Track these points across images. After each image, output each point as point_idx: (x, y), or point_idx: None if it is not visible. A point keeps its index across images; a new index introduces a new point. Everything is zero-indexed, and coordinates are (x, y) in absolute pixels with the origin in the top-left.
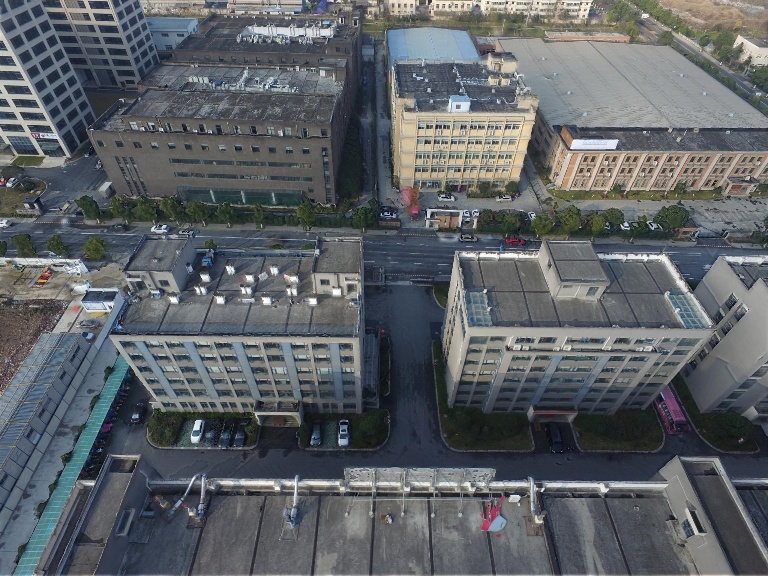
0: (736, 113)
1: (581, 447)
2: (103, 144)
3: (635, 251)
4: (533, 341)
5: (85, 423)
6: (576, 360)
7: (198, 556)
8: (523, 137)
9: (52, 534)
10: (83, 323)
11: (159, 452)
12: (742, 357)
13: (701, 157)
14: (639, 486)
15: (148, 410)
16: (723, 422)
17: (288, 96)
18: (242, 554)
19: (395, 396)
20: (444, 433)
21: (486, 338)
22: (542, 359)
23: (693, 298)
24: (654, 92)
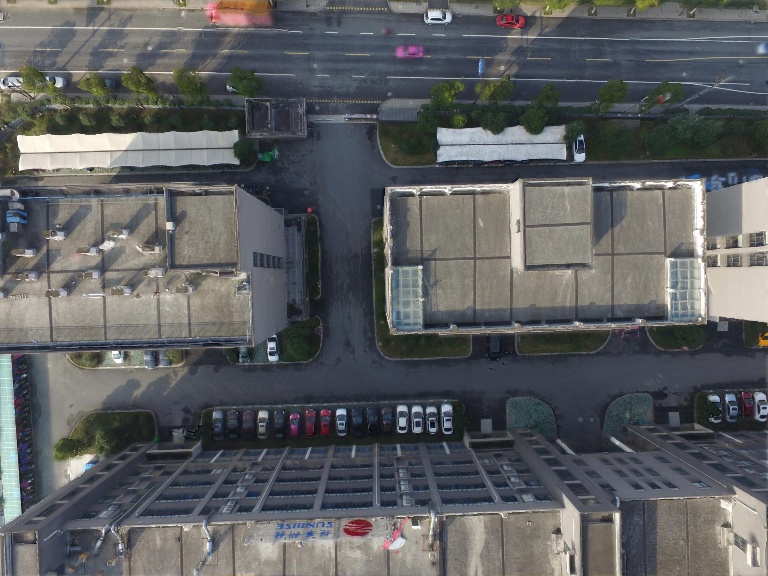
0: None
1: (519, 351)
2: None
3: (690, 35)
4: None
5: None
6: None
7: None
8: None
9: None
10: None
11: (86, 373)
12: (730, 302)
13: None
14: None
15: None
16: (677, 330)
17: None
18: None
19: (327, 299)
20: (379, 342)
21: None
22: None
23: (702, 269)
24: None
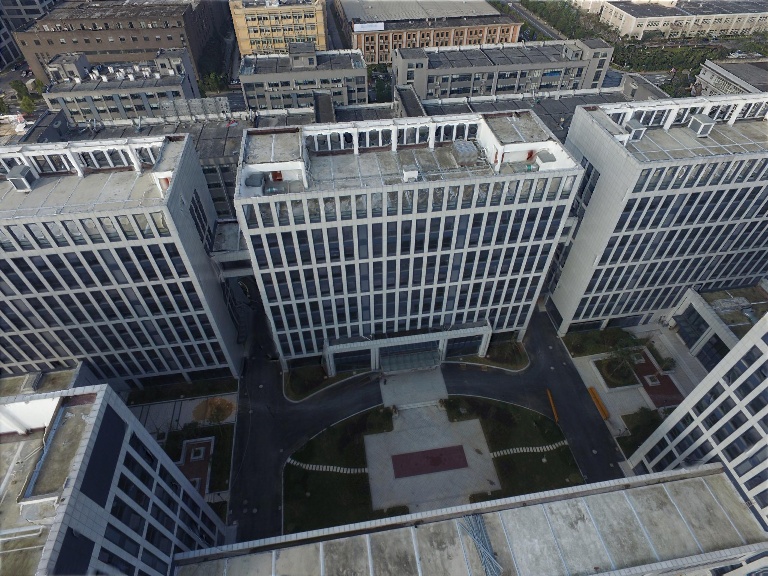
0: (479, 11)
1: None
2: (25, 43)
3: None
4: (278, 85)
5: None
6: (306, 97)
7: None
8: (319, 23)
9: None
10: None
11: None
12: None
13: (443, 33)
14: (303, 111)
15: None
16: None
17: (155, 7)
18: None
19: None
20: None
21: (253, 86)
22: (287, 98)
23: None
24: (429, 3)
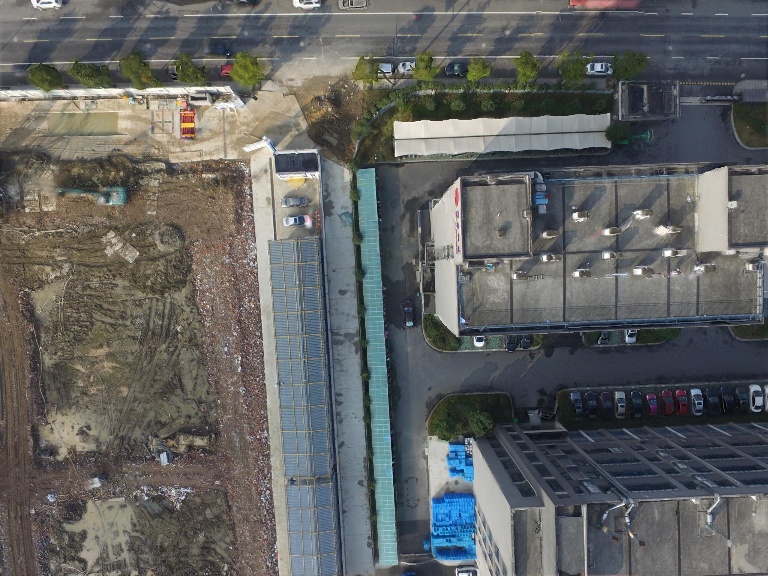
0: None
1: None
2: None
3: None
4: None
5: (365, 338)
6: None
7: (633, 553)
8: None
9: (513, 553)
10: (290, 203)
11: (445, 356)
12: None
13: None
14: None
15: (416, 312)
16: None
17: None
18: (669, 549)
19: None
20: None
21: None
22: None
23: None
24: None
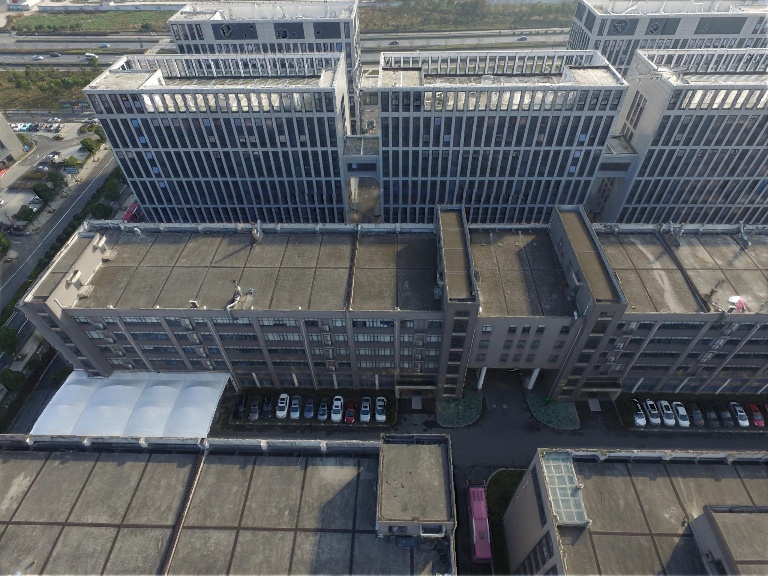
0: None
1: None
2: None
3: None
4: None
5: None
6: None
7: None
8: None
9: None
10: None
11: None
12: None
13: None
14: None
15: None
16: None
17: None
18: None
19: None
20: None
21: None
22: None
23: None
24: None
